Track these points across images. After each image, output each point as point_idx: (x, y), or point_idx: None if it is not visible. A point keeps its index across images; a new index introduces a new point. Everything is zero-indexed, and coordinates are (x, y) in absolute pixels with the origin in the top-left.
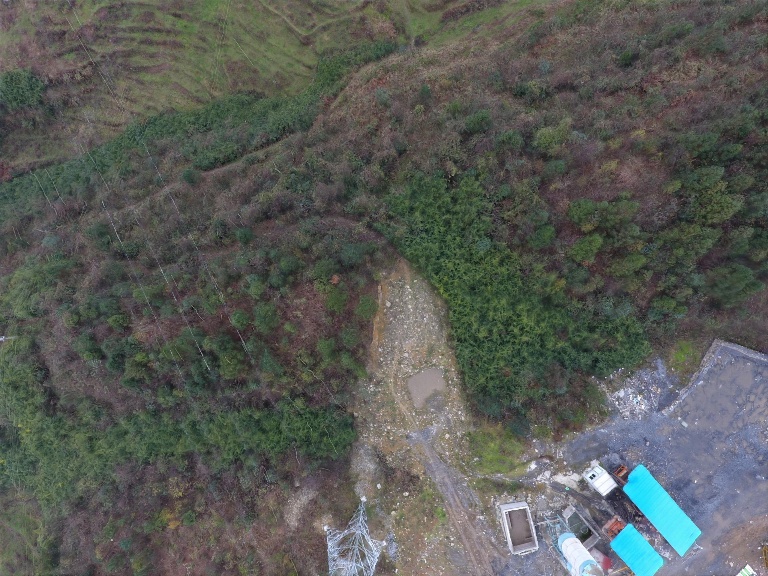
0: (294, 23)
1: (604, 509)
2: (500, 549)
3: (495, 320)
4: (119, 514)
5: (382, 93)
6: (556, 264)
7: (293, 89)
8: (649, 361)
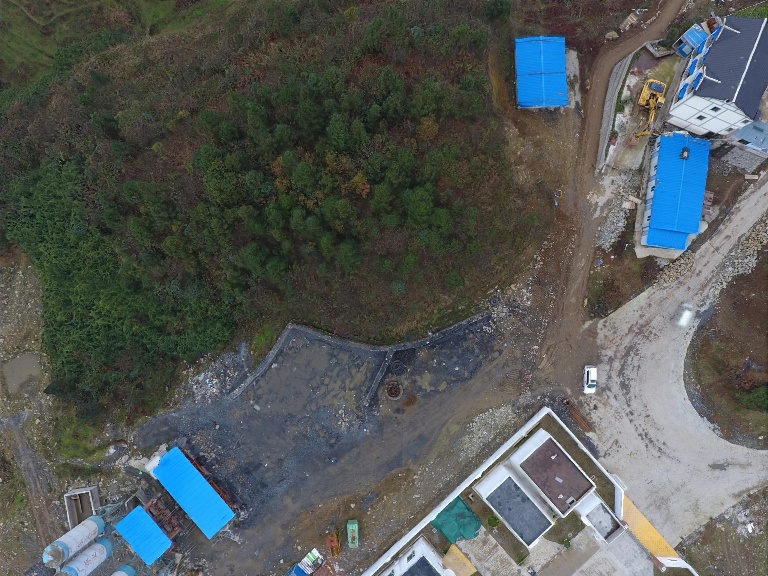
0: (31, 13)
1: None
2: None
3: (77, 304)
4: None
5: (72, 81)
6: (133, 247)
7: (38, 80)
8: (235, 345)
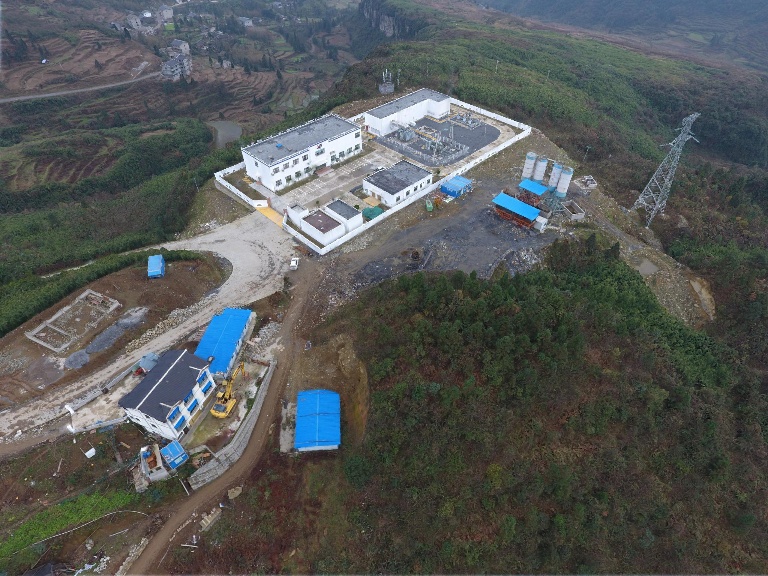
0: None
1: None
2: None
3: None
4: (764, 232)
5: None
6: None
7: None
8: None
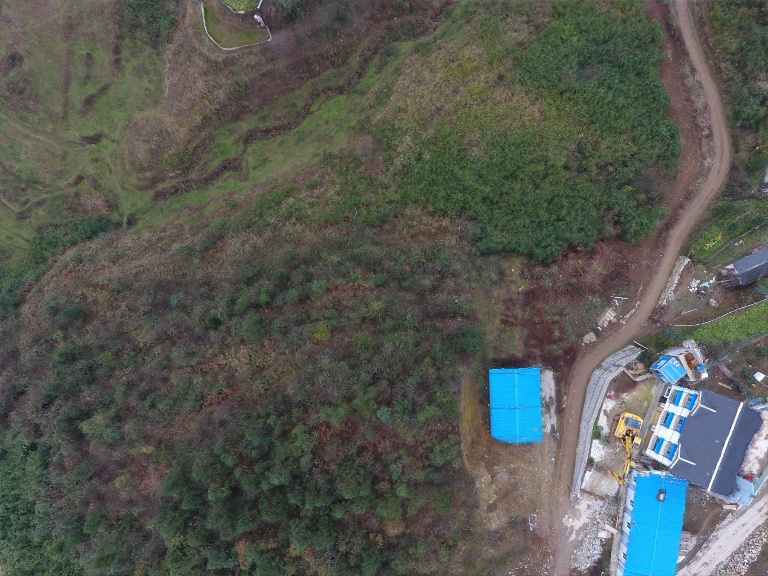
0: (6, 199)
1: None
2: None
3: None
4: None
5: (44, 304)
6: None
7: (13, 262)
8: None
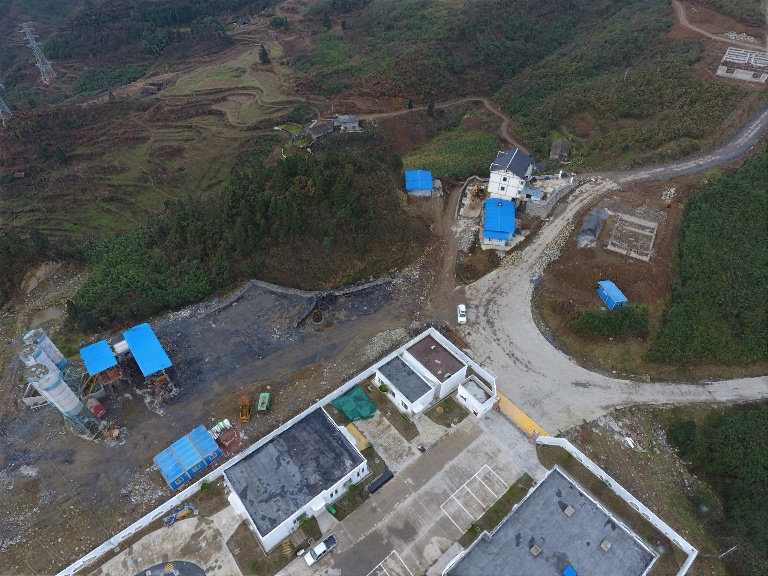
0: None
1: (125, 379)
2: (19, 406)
3: None
4: None
5: None
6: None
7: None
8: (210, 299)
